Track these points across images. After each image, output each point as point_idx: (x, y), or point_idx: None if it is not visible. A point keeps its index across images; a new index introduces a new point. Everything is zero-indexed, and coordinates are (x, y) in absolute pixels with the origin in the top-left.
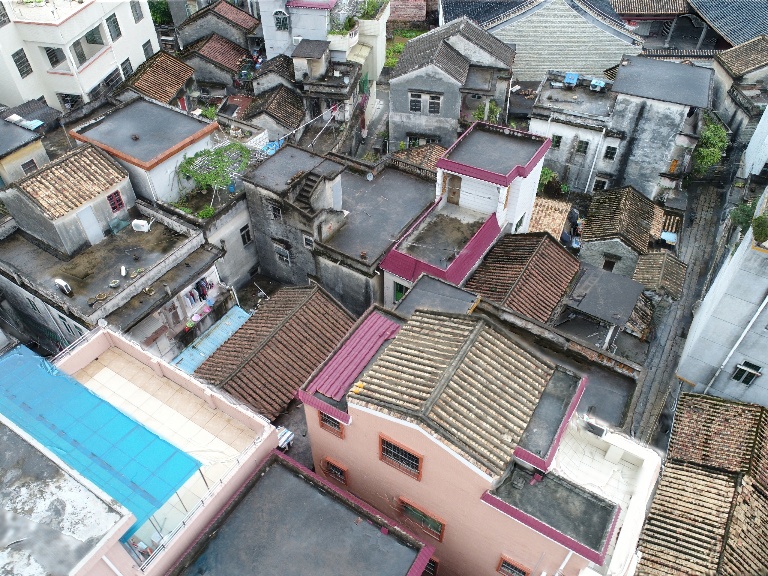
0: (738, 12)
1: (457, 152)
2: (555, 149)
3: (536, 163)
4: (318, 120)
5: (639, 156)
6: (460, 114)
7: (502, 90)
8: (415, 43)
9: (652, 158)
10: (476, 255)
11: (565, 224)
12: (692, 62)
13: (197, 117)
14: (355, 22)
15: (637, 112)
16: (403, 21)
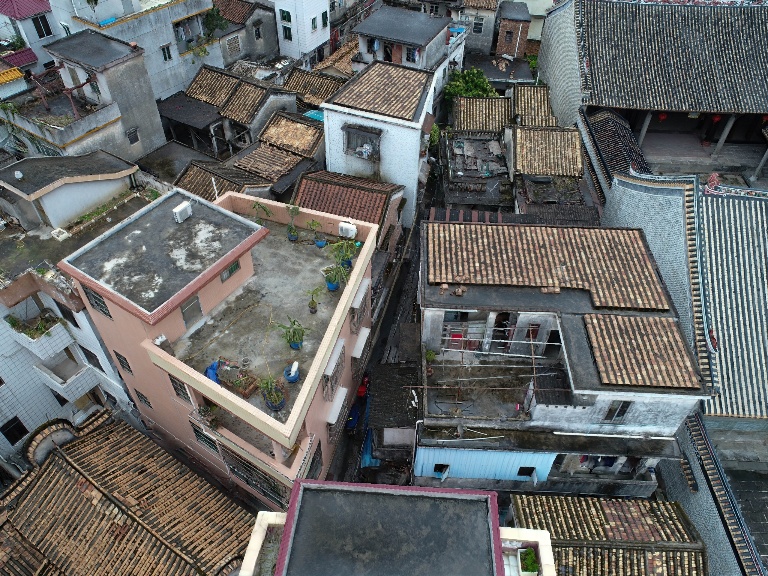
0: None
1: None
2: None
3: None
4: None
5: None
6: None
7: None
8: None
9: None
10: None
11: None
12: None
13: None
14: None
15: None
16: None
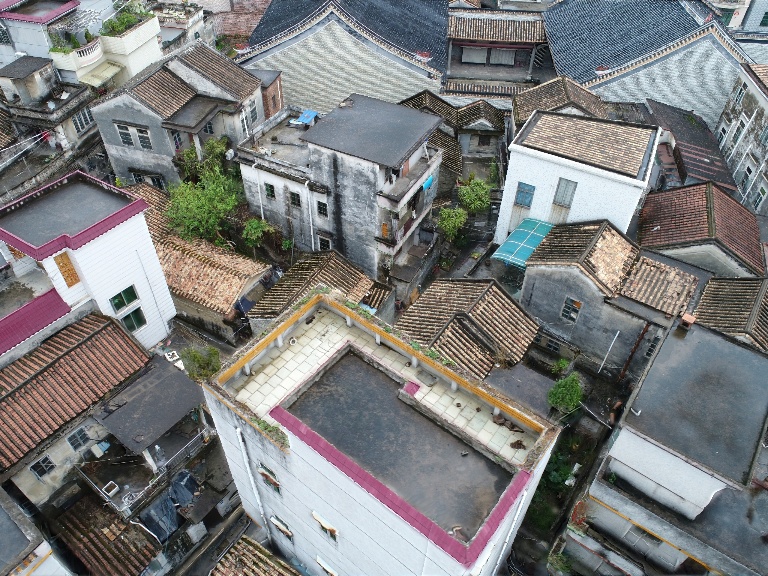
0: (581, 45)
1: (24, 210)
2: (272, 199)
3: (103, 231)
4: (44, 147)
5: (349, 215)
6: (176, 151)
7: (232, 126)
8: (151, 66)
9: (362, 219)
10: (5, 342)
11: (253, 291)
12: (500, 101)
13: None
14: (94, 38)
15: (332, 165)
16: (245, 36)
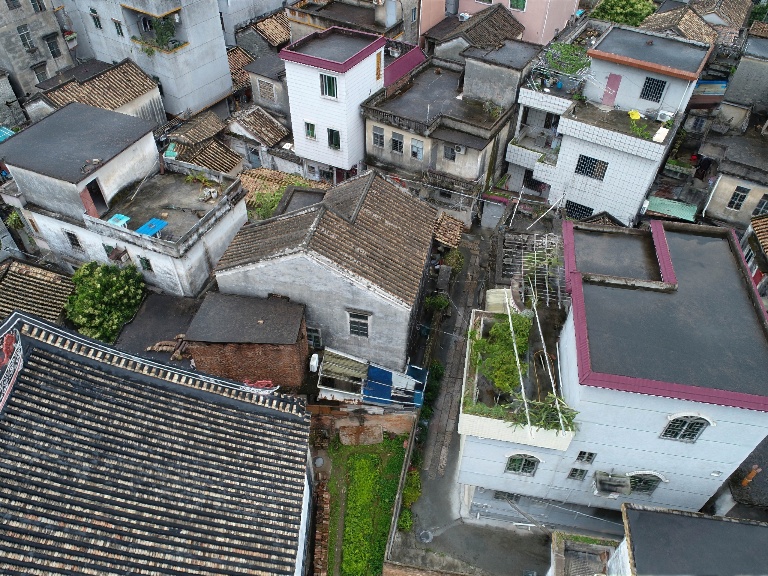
0: None
1: None
2: None
3: None
4: None
5: None
6: None
7: None
8: None
9: None
10: None
11: None
12: None
13: (613, 55)
14: None
15: None
16: None
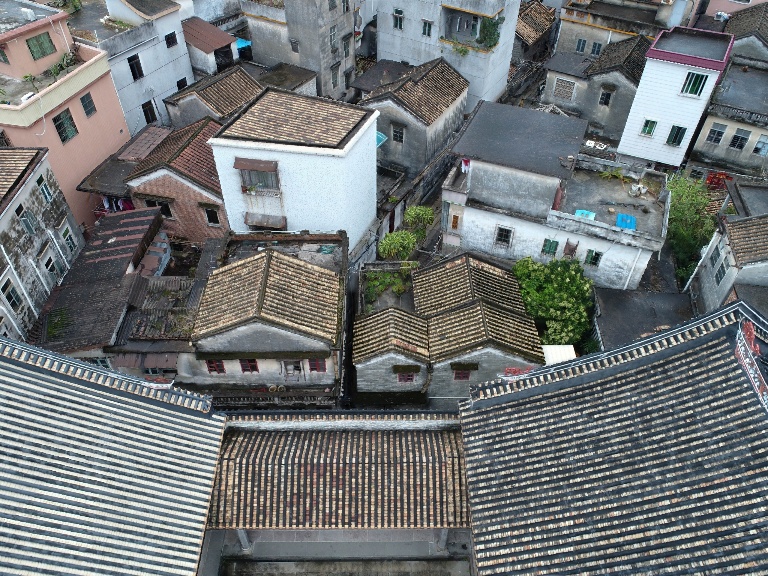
0: None
1: (724, 49)
2: None
3: None
4: None
5: None
6: None
7: None
8: None
9: None
10: None
11: None
12: None
13: None
14: None
15: None
16: None
